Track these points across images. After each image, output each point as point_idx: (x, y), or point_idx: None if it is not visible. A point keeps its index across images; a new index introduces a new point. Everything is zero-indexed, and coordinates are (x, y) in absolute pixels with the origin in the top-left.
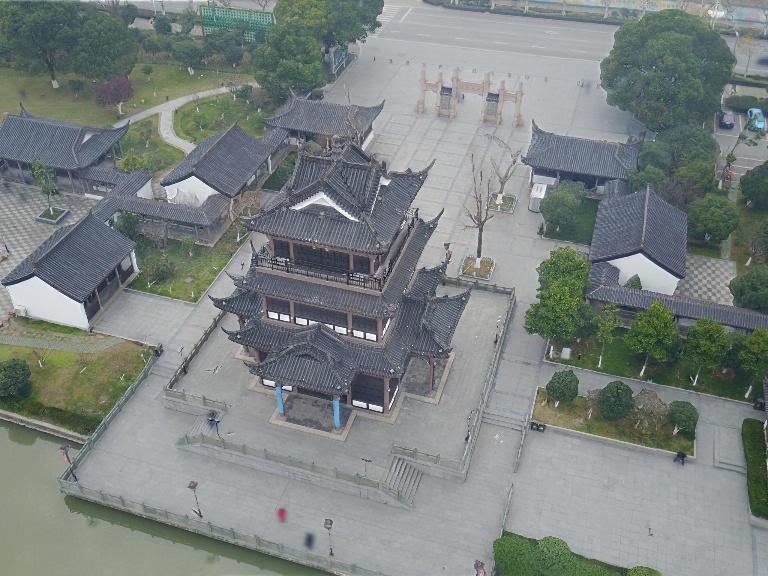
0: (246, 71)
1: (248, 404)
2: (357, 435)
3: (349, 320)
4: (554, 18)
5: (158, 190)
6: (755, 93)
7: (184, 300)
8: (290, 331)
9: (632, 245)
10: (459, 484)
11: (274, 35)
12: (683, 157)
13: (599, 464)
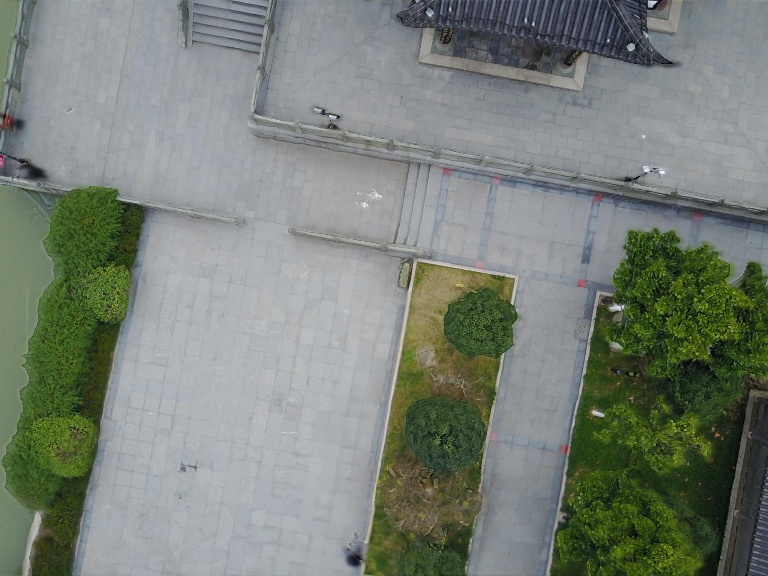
0: None
1: None
2: None
3: None
4: None
5: None
6: None
7: None
8: None
9: None
10: None
11: None
12: None
13: (331, 390)
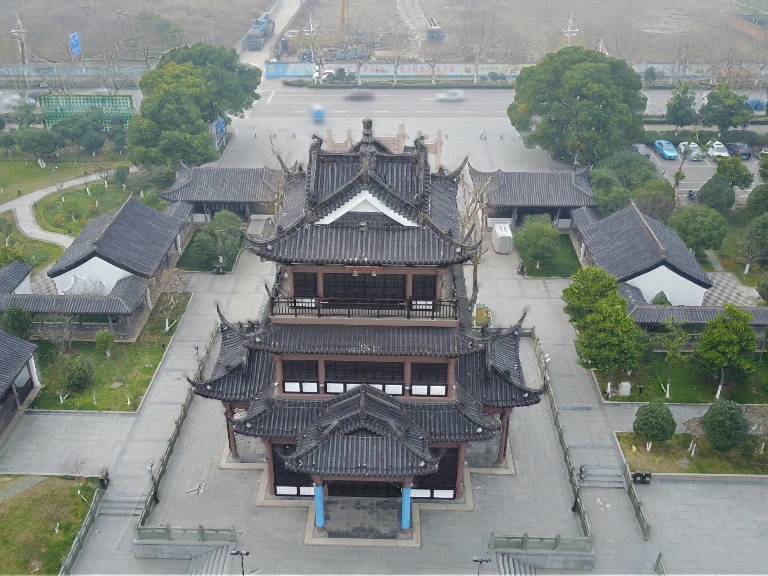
0: (110, 158)
1: (264, 526)
2: (433, 535)
3: (407, 372)
4: (426, 87)
5: (37, 289)
6: (651, 129)
7: (118, 411)
8: (319, 405)
9: (650, 259)
10: (587, 571)
11: (151, 105)
12: (634, 180)
13: (734, 508)
